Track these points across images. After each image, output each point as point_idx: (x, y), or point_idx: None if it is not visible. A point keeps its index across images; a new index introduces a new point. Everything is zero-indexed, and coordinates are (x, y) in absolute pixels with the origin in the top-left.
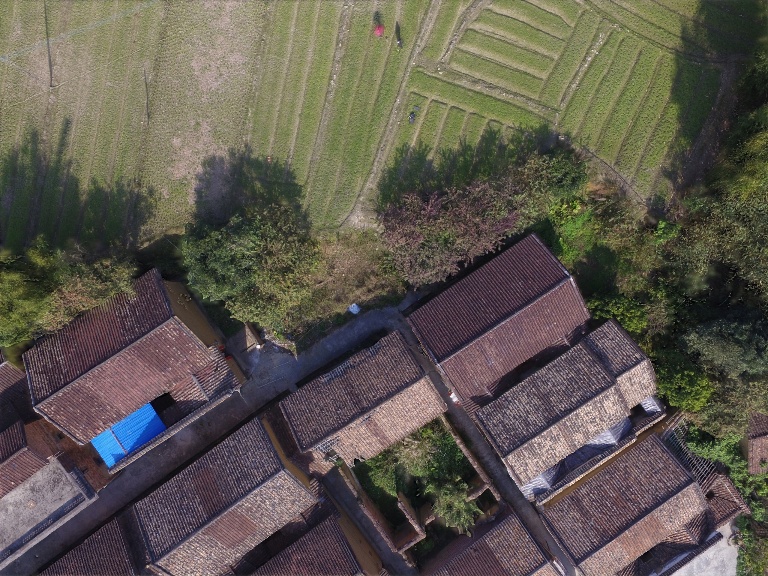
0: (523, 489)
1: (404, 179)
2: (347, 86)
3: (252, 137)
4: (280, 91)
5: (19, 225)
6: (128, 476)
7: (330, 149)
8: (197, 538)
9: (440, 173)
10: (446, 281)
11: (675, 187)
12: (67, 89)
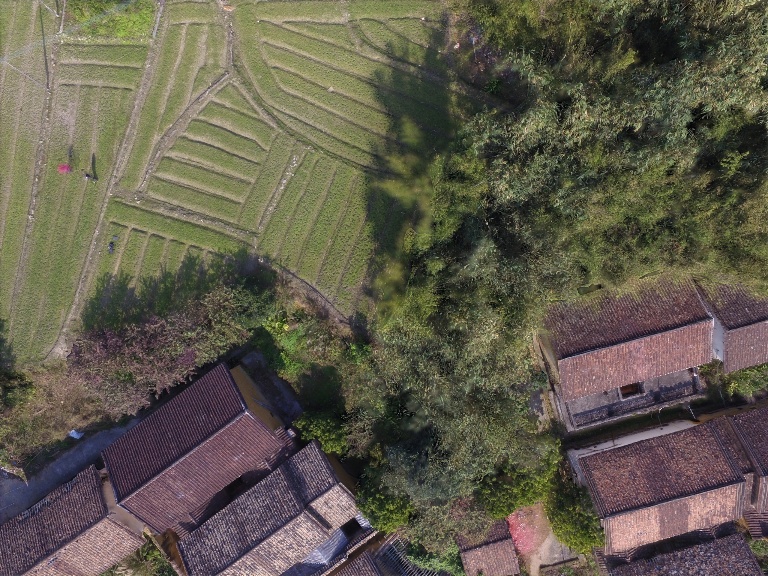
0: None
1: (107, 308)
2: (45, 220)
3: None
4: None
5: None
6: None
7: (31, 283)
8: None
9: (142, 301)
10: (145, 411)
11: (377, 303)
12: None
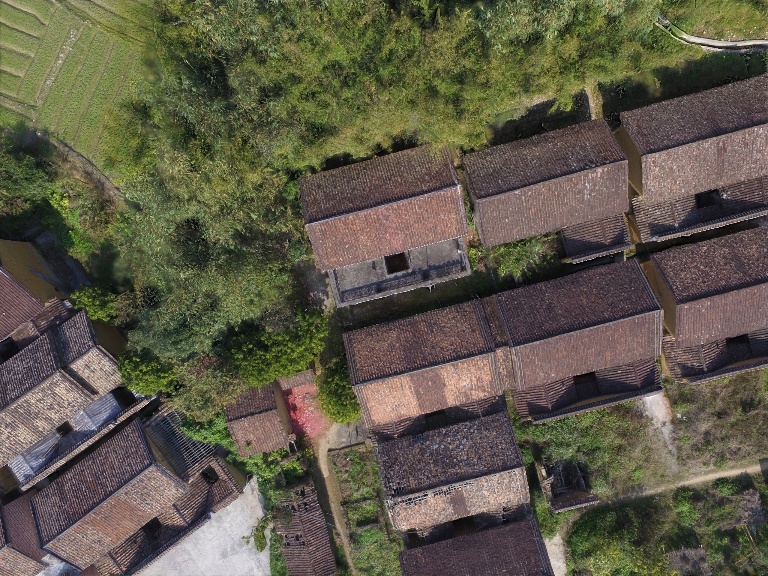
0: (18, 475)
1: None
2: None
3: None
4: None
5: None
6: None
7: None
8: None
9: None
10: None
11: None
12: None
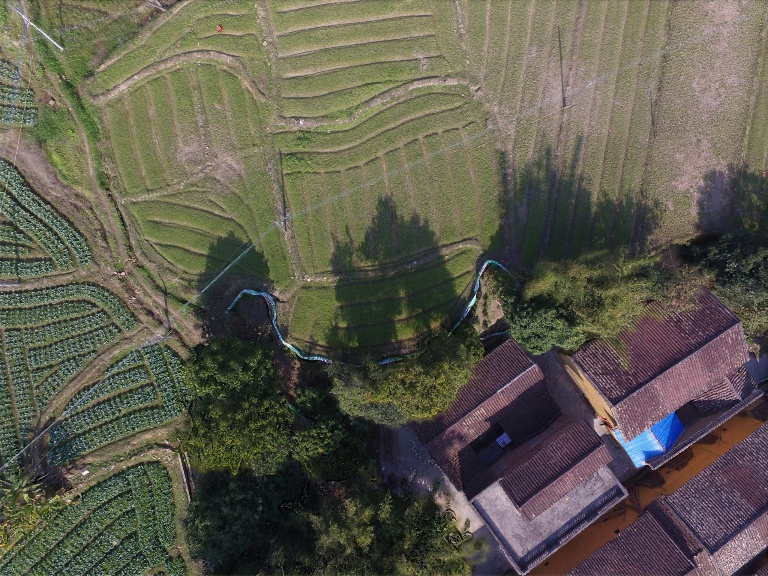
0: None
1: None
2: None
3: (747, 153)
4: None
5: (536, 235)
6: None
7: None
8: (747, 530)
9: None
10: None
11: None
12: (579, 108)
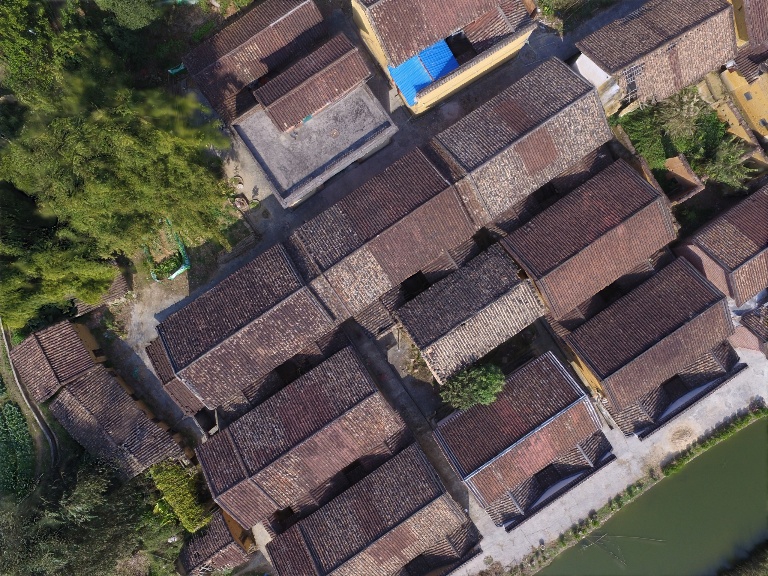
0: None
1: None
2: None
3: None
4: None
5: None
6: (397, 147)
7: None
8: (509, 153)
9: None
10: None
11: None
12: None
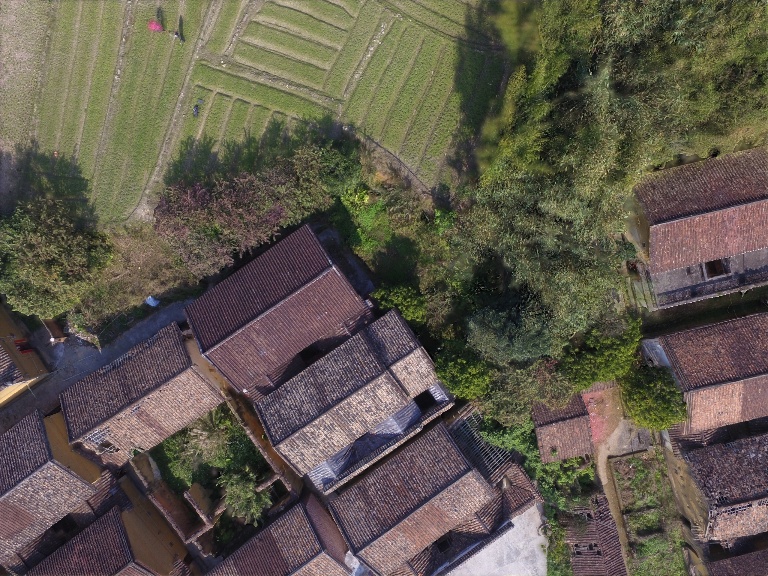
0: (313, 479)
1: (190, 172)
2: (131, 80)
3: (39, 132)
4: (66, 87)
5: None
6: None
7: (115, 143)
8: None
9: (225, 165)
10: (227, 272)
11: (460, 175)
12: None
